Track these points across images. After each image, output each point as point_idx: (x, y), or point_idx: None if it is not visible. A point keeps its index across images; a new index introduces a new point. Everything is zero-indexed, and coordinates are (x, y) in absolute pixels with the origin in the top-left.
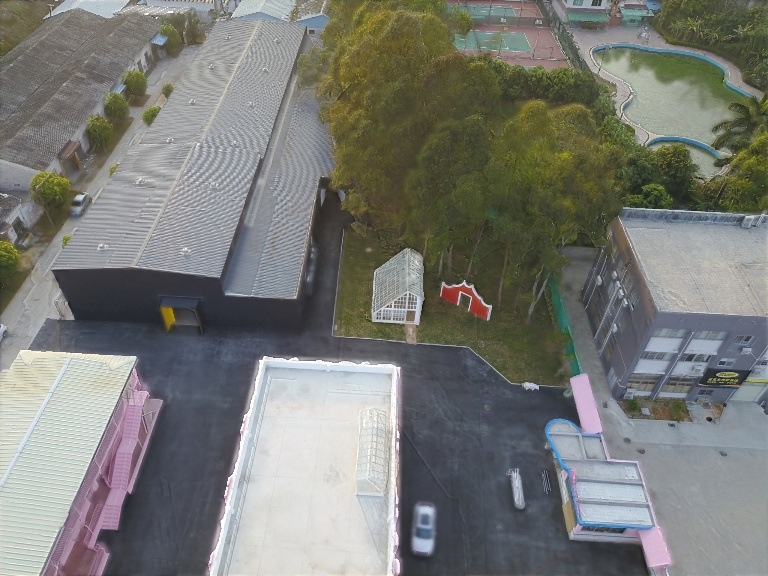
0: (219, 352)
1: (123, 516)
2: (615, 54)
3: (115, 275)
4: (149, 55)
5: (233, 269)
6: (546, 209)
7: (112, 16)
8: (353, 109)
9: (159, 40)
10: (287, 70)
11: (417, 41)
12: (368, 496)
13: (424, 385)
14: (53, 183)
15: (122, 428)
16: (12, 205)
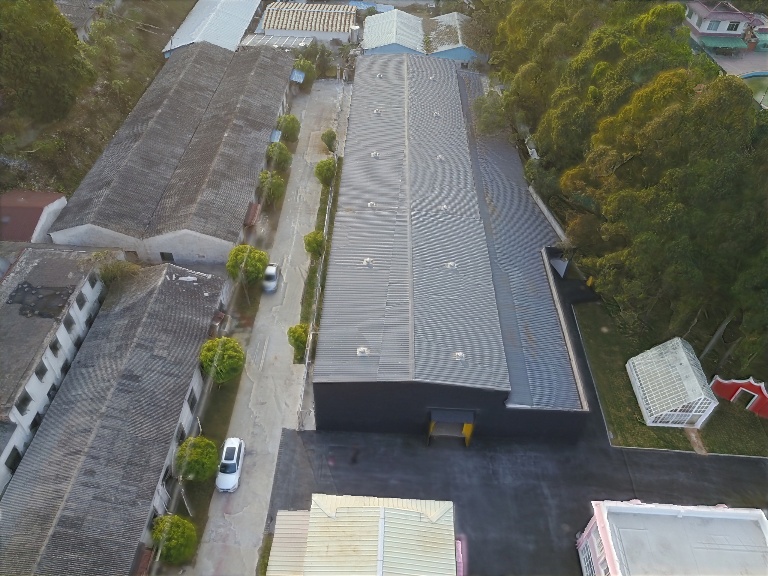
0: (495, 472)
1: None
2: (761, 84)
3: (387, 388)
4: (287, 93)
5: None
6: None
7: (234, 48)
8: (618, 179)
9: (297, 77)
10: (458, 114)
11: (745, 113)
12: None
13: None
14: (254, 259)
15: None
16: (218, 288)
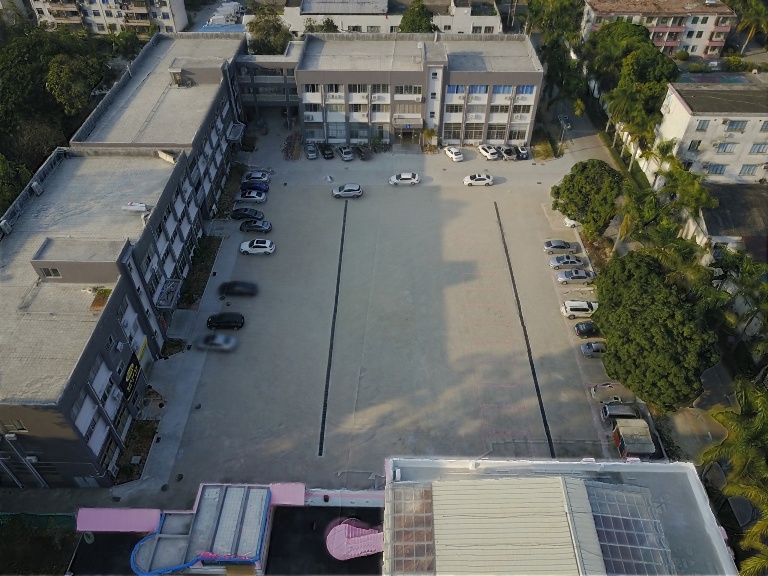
0: None
1: None
2: None
3: None
4: None
5: None
6: None
7: None
8: None
9: None
10: None
11: None
12: None
13: None
14: None
15: None
16: None
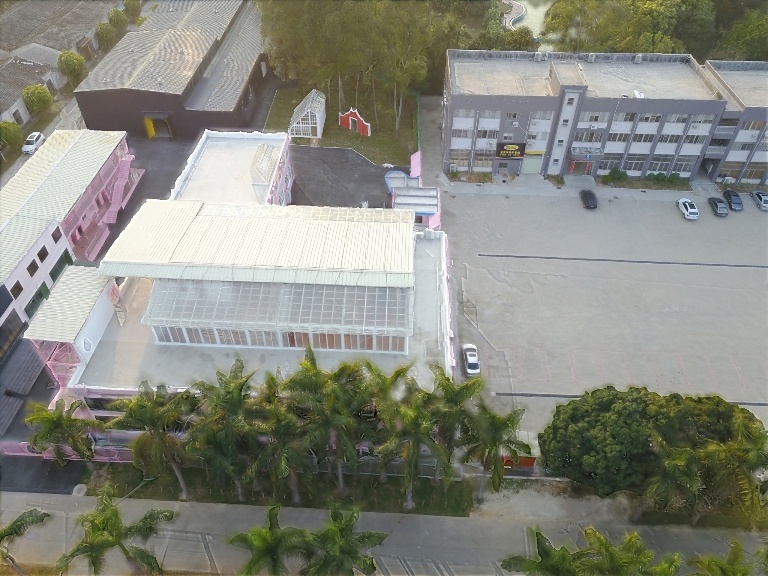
0: (183, 149)
1: (119, 217)
2: None
3: (114, 95)
4: None
5: (193, 98)
6: (378, 30)
7: None
8: None
9: None
10: None
11: None
12: (258, 185)
13: (317, 166)
14: (73, 58)
15: (118, 172)
16: (46, 70)
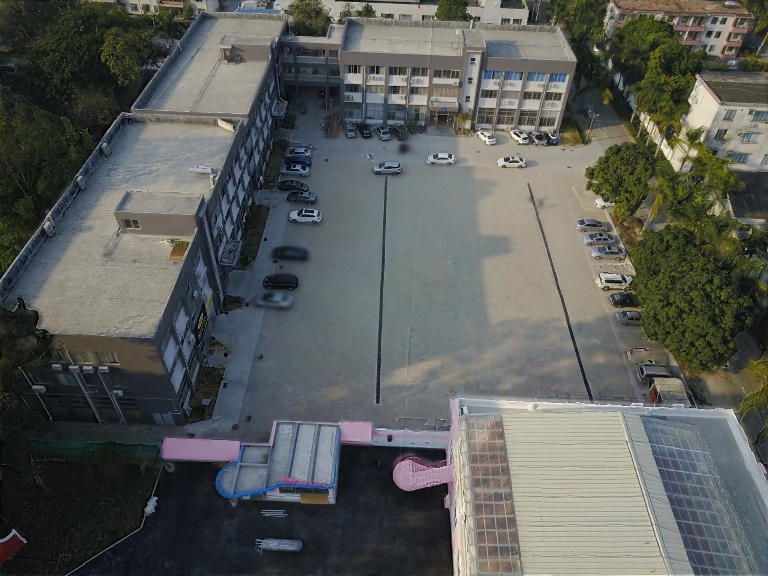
0: None
1: None
2: None
3: None
4: None
5: None
6: None
7: None
8: None
9: None
10: None
11: None
12: None
13: None
14: None
15: None
16: None
